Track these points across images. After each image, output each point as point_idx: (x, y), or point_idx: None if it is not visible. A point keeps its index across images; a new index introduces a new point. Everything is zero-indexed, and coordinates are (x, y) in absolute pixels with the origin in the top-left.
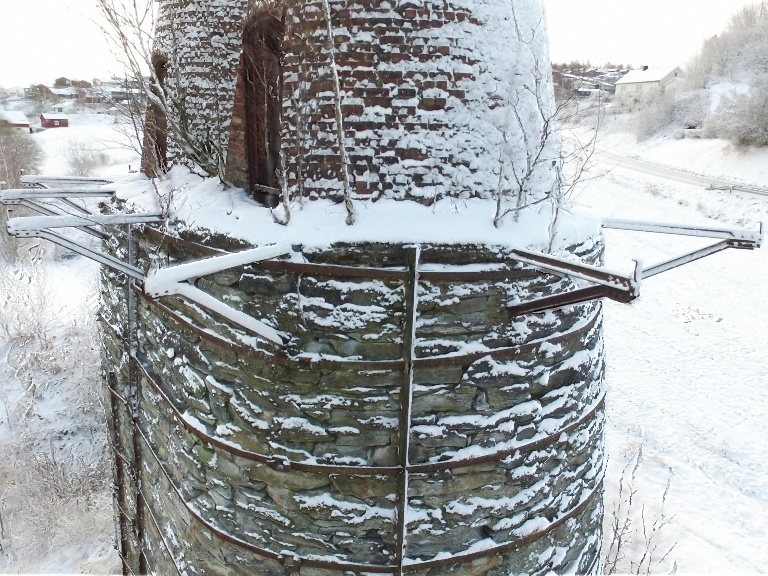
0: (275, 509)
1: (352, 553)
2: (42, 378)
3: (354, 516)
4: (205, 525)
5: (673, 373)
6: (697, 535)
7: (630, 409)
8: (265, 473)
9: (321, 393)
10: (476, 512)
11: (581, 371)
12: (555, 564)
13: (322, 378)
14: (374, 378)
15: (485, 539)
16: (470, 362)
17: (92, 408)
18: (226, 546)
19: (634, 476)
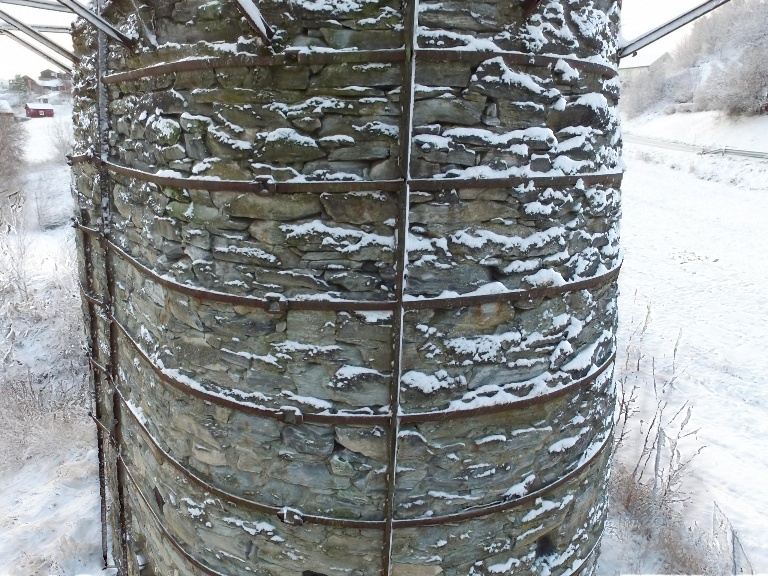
0: (259, 247)
1: (346, 291)
2: (22, 327)
3: (348, 244)
4: (181, 289)
5: (671, 305)
6: (701, 437)
7: (628, 336)
8: (247, 204)
9: (310, 98)
10: (485, 246)
11: (599, 116)
12: (570, 335)
13: (311, 79)
14: (371, 74)
15: (495, 281)
16: (479, 61)
17: (73, 351)
18: (204, 308)
19: (642, 338)
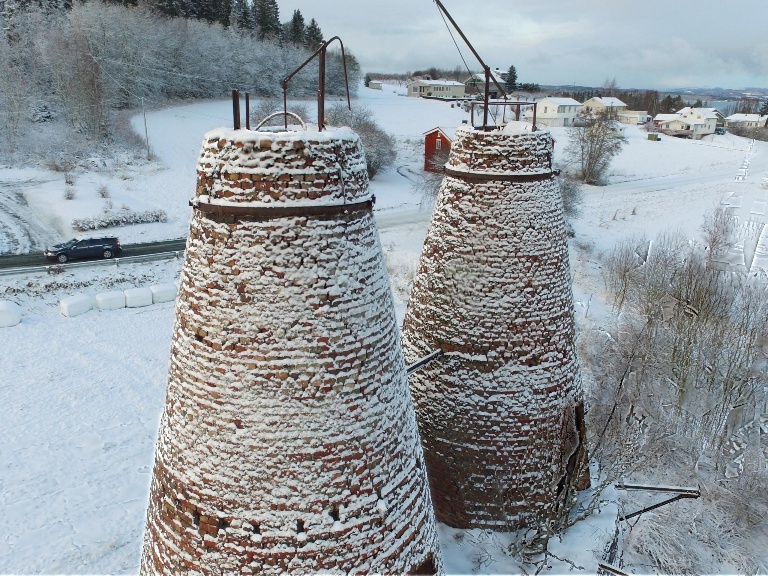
0: None
1: None
2: None
3: None
4: None
5: None
6: None
7: None
8: None
9: None
10: None
11: None
12: None
13: None
14: None
15: None
16: None
17: None
18: None
19: None
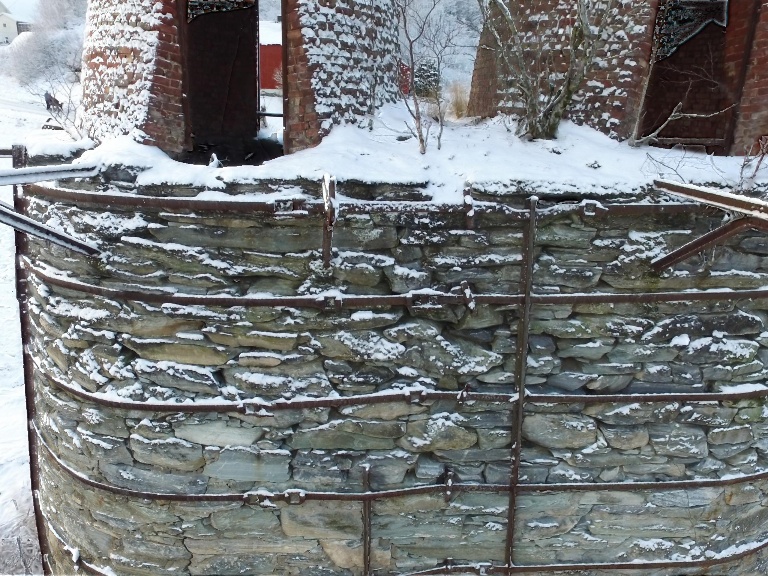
0: None
1: None
2: None
3: None
4: None
5: None
6: None
7: None
8: None
9: None
10: None
11: None
12: None
13: None
14: None
15: None
16: None
17: None
18: (766, 482)
19: None
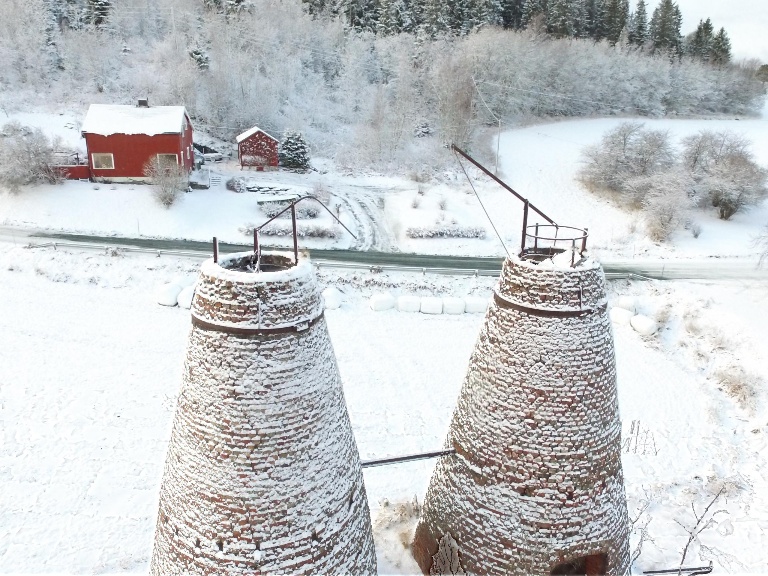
0: None
1: None
2: None
3: None
4: None
5: None
6: None
7: None
8: None
9: None
10: None
11: None
12: None
13: None
14: None
15: None
16: None
17: None
18: None
19: None
